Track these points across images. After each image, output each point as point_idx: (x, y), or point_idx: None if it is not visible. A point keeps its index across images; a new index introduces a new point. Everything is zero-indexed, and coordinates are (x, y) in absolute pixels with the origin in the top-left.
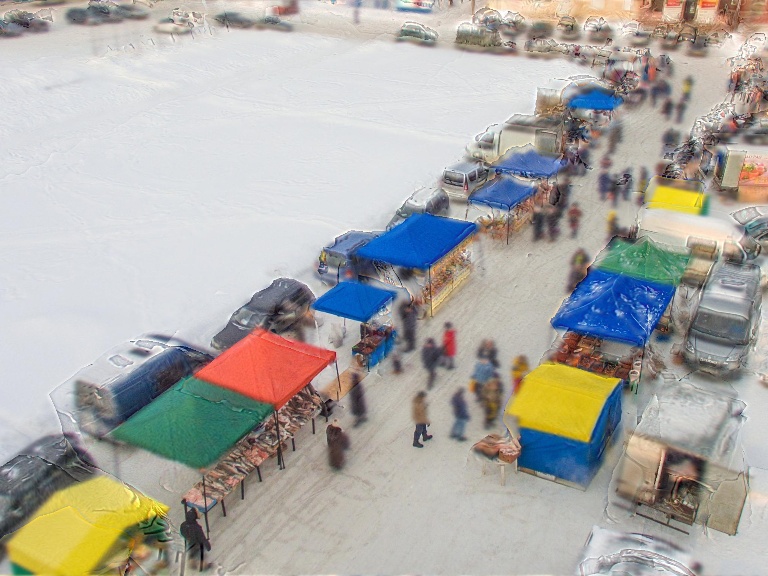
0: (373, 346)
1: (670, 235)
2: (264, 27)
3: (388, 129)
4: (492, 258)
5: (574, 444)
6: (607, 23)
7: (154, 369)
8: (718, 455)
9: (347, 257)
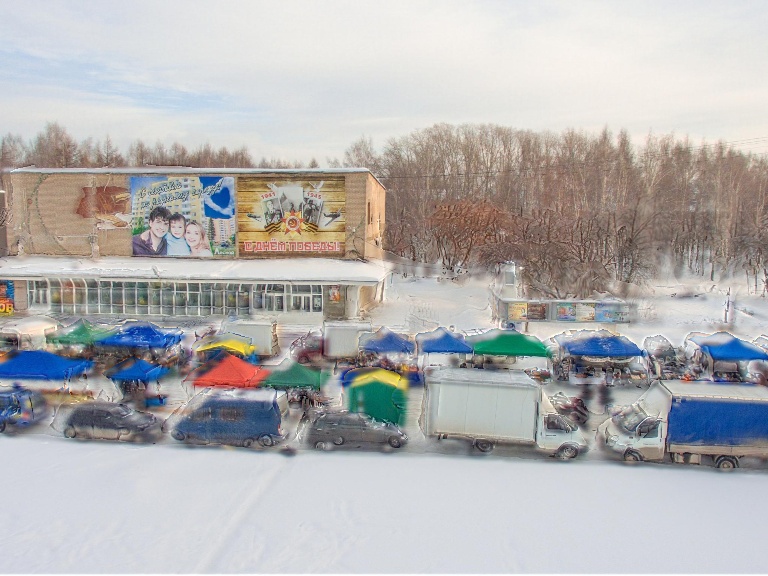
0: None
1: None
2: None
3: None
4: None
5: None
6: None
7: None
8: None
9: (30, 390)
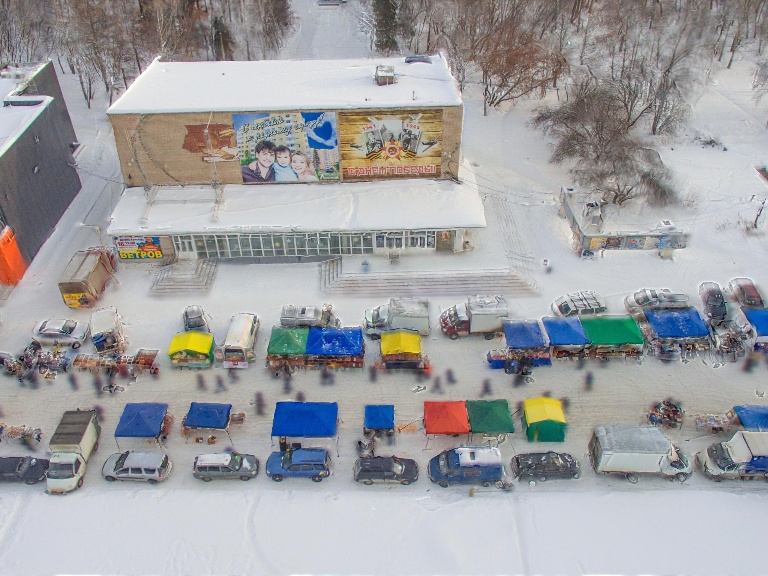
0: None
1: None
2: None
3: None
4: (262, 419)
5: None
6: None
7: None
8: None
9: None
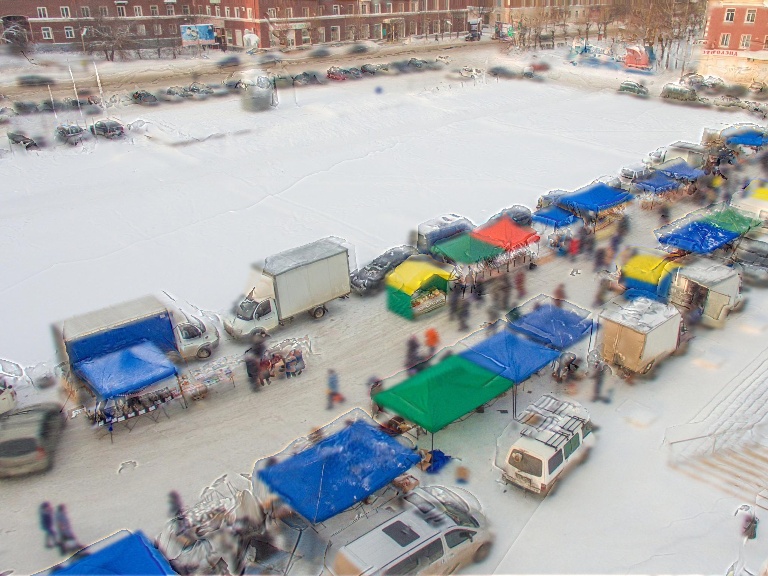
0: (559, 236)
1: (749, 209)
2: (522, 80)
3: (594, 146)
4: (639, 215)
5: (645, 271)
6: None
7: (460, 224)
8: (705, 271)
9: (554, 200)
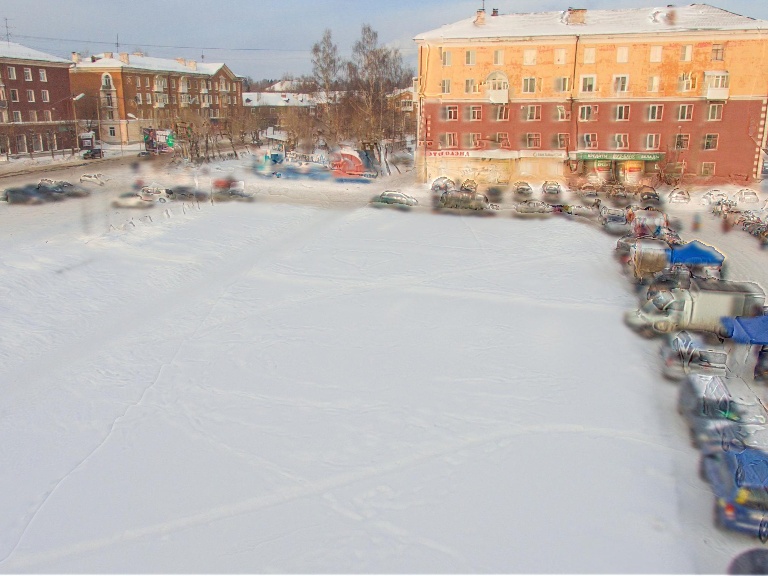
0: None
1: None
2: (248, 200)
3: (518, 300)
4: None
5: None
6: (560, 186)
7: None
8: None
9: None
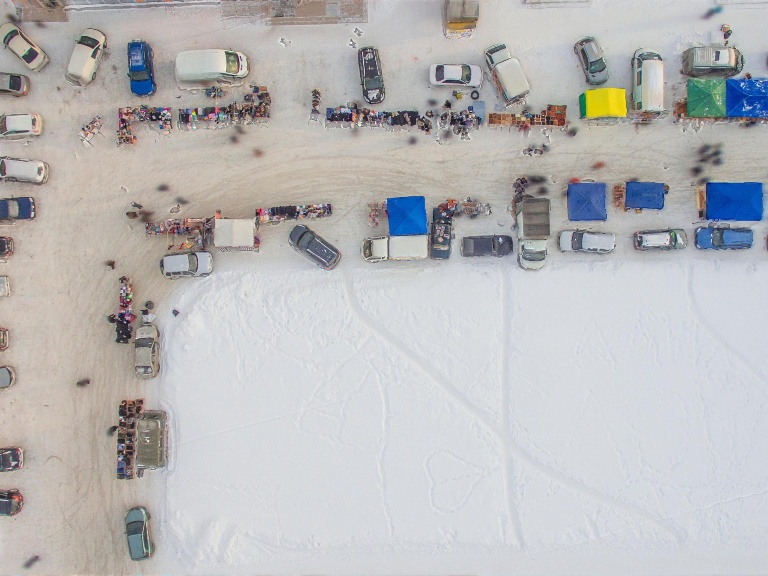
0: None
1: None
2: None
3: (524, 346)
4: (678, 185)
5: None
6: None
7: None
8: None
9: None
